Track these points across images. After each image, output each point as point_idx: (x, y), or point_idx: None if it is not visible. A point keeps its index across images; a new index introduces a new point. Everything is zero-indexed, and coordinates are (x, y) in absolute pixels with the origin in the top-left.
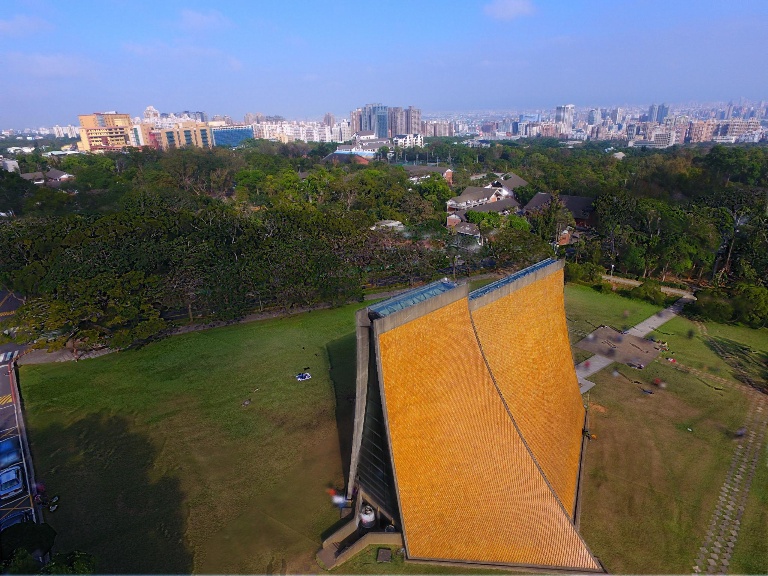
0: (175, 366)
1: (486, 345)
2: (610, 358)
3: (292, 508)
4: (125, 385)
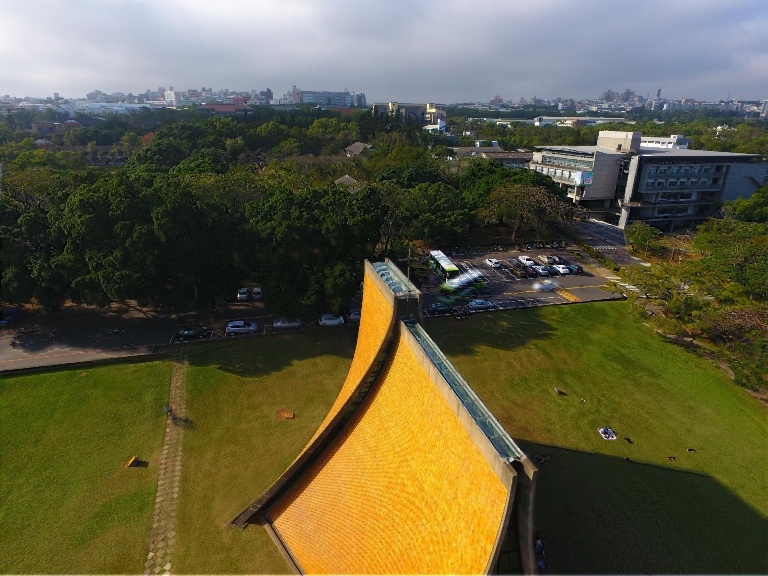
0: (631, 359)
1: (395, 384)
2: None
3: None
4: (594, 336)
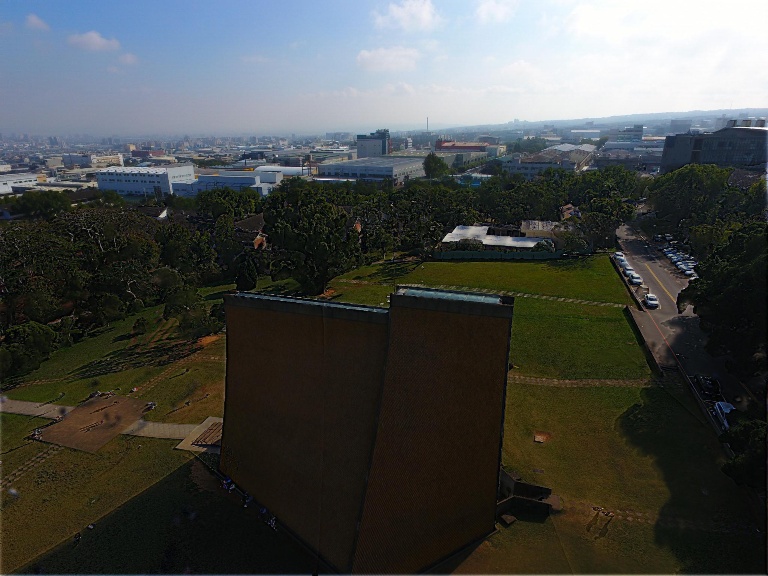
0: None
1: None
2: (131, 423)
3: (549, 567)
4: None
